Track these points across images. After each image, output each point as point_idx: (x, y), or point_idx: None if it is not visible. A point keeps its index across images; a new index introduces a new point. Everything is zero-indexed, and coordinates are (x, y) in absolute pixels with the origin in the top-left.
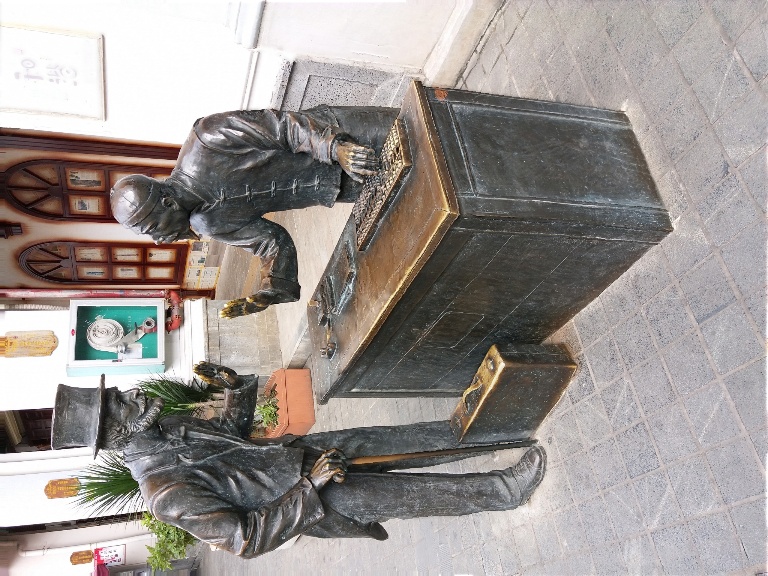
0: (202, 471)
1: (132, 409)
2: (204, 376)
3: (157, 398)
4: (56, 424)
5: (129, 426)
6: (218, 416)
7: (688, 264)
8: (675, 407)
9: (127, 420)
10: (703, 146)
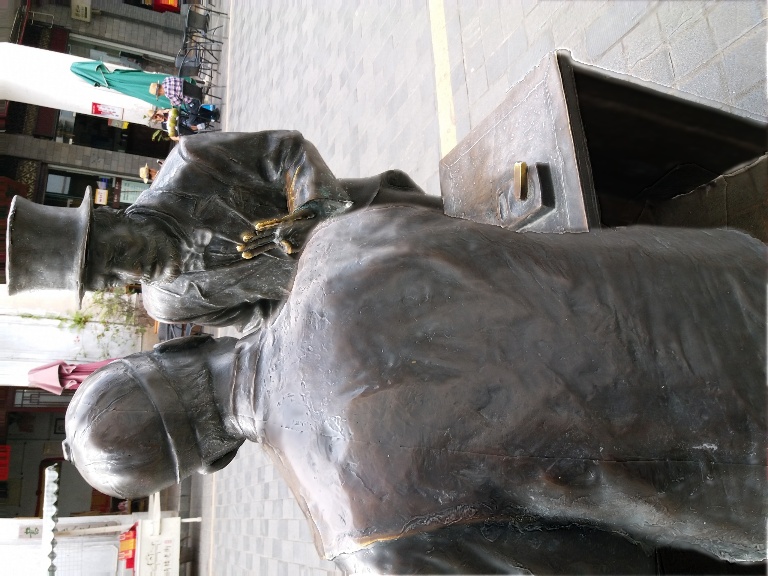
0: None
1: None
2: (252, 255)
3: (171, 265)
4: None
5: None
6: (283, 148)
7: None
8: None
9: None
10: None
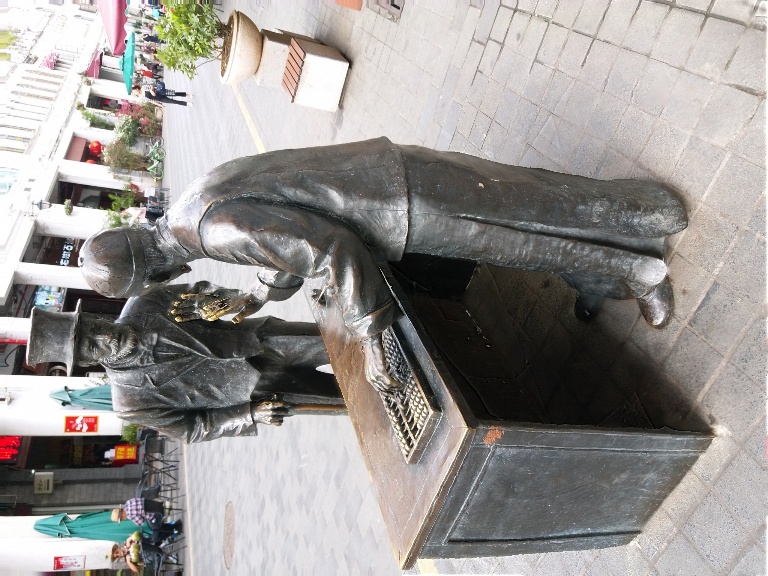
0: (163, 396)
1: (104, 353)
2: (182, 319)
3: (131, 336)
4: (30, 364)
5: (101, 360)
6: (199, 286)
7: (610, 567)
8: (529, 567)
9: (99, 358)
10: (703, 570)
